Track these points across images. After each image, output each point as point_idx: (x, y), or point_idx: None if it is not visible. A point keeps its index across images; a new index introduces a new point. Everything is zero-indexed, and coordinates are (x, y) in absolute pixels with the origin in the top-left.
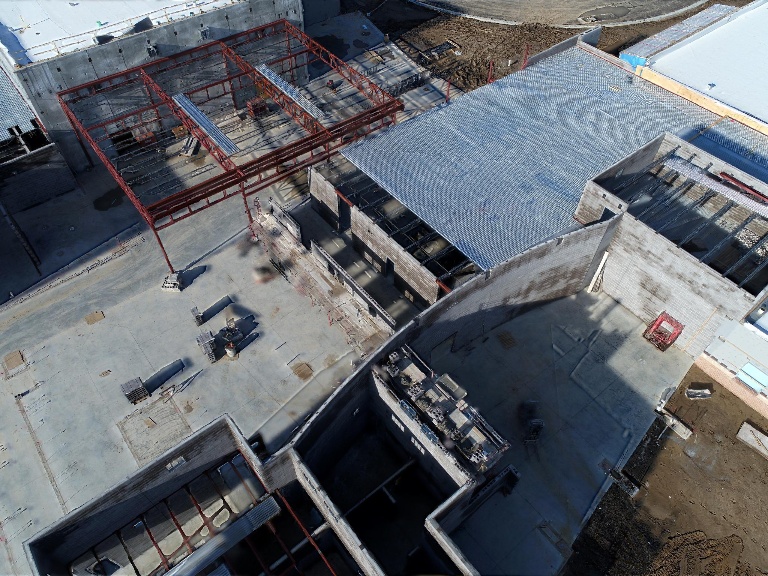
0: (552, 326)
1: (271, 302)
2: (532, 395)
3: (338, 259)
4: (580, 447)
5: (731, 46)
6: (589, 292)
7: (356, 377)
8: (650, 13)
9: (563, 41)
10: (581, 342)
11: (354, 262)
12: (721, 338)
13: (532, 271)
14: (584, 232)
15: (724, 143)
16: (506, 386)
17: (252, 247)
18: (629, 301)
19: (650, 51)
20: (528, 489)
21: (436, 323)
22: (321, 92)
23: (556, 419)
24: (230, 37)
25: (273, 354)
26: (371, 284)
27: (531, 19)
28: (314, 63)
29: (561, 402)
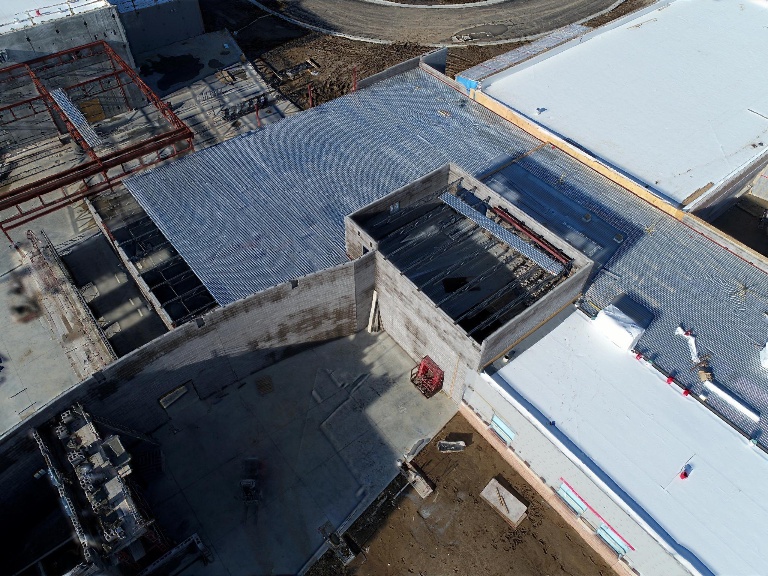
0: (318, 370)
1: (25, 343)
2: (272, 448)
3: (114, 296)
4: (306, 507)
5: (576, 68)
6: (369, 332)
7: (6, 441)
8: (528, 31)
9: (401, 63)
10: (344, 388)
11: (130, 299)
12: (471, 387)
13: (273, 314)
14: (324, 273)
15: (536, 172)
16: (247, 438)
17: (26, 282)
18: (403, 343)
19: (483, 74)
20: (233, 557)
21: (142, 375)
22: (157, 114)
23: (290, 475)
24: (37, 59)
25: (7, 402)
26: (140, 323)
27: (403, 38)
28: (161, 84)
29: (301, 456)
